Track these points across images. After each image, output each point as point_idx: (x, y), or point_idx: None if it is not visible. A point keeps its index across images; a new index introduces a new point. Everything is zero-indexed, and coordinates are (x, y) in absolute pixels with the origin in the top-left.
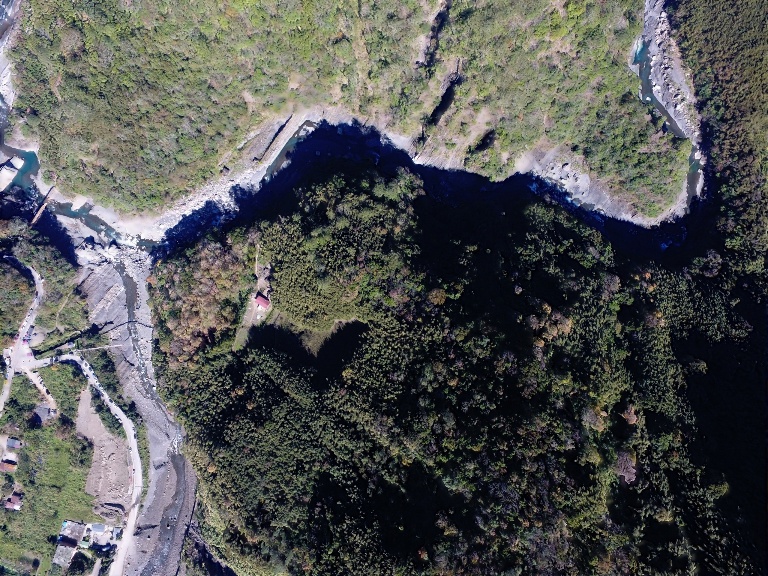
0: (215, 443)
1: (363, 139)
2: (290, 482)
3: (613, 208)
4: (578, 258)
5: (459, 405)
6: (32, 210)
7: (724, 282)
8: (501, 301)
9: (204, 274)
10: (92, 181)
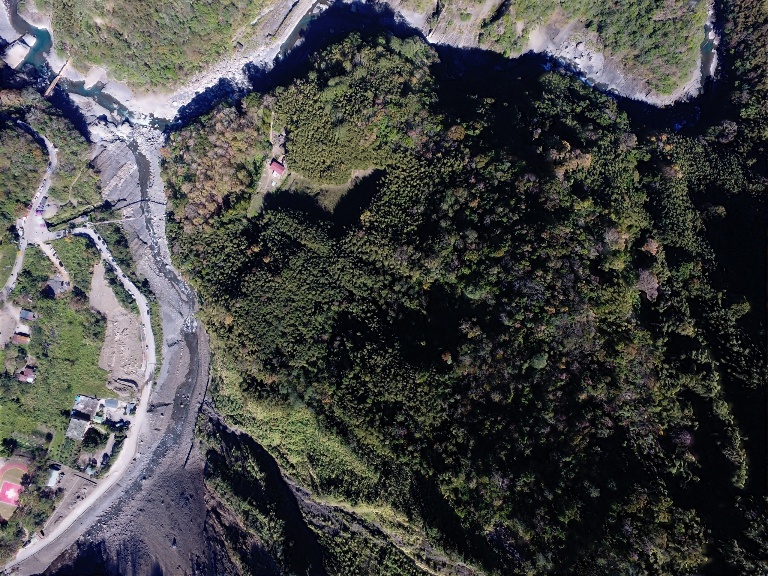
0: (232, 296)
1: (377, 17)
2: (308, 323)
3: (627, 87)
4: (595, 116)
5: (481, 222)
6: (44, 87)
7: (740, 146)
8: (520, 140)
9: (219, 137)
10: (106, 44)
